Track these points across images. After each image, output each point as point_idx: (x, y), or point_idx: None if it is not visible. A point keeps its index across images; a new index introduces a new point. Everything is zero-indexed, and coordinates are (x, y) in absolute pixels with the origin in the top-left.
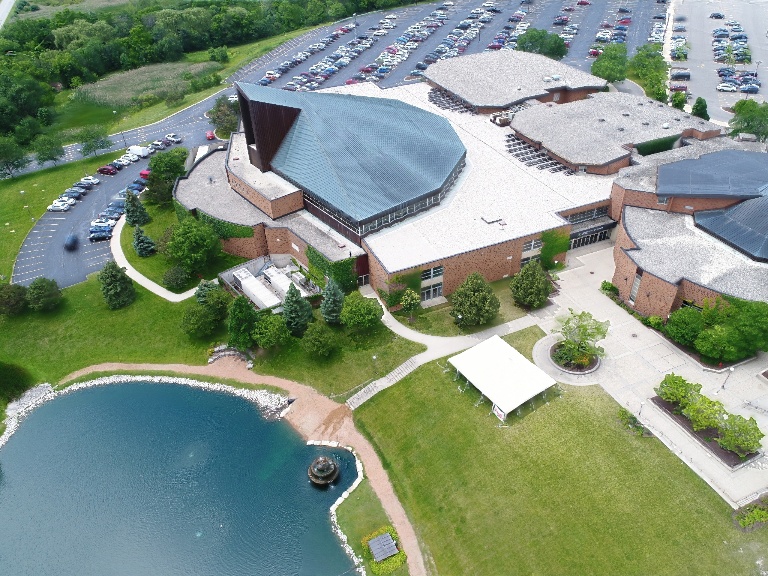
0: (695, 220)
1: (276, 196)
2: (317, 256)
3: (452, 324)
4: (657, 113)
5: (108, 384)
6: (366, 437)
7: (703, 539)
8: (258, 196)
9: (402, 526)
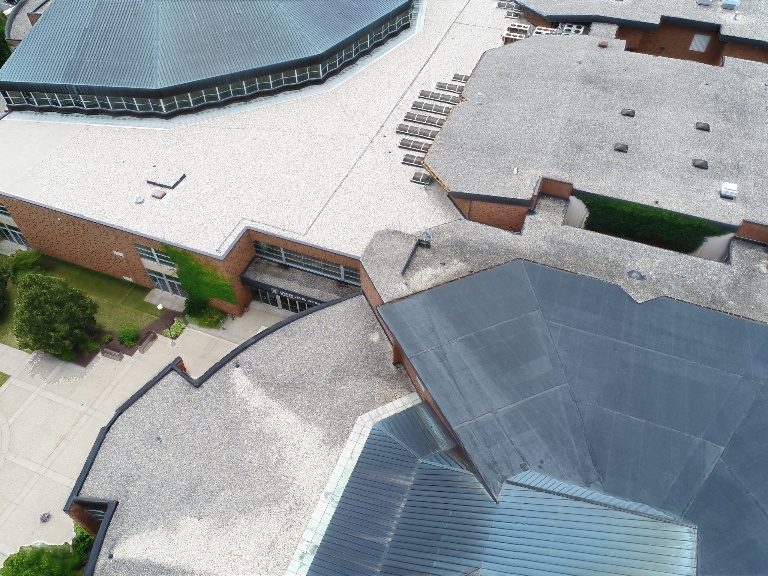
0: None
1: None
2: None
3: None
4: None
5: None
6: None
7: None
8: None
9: None
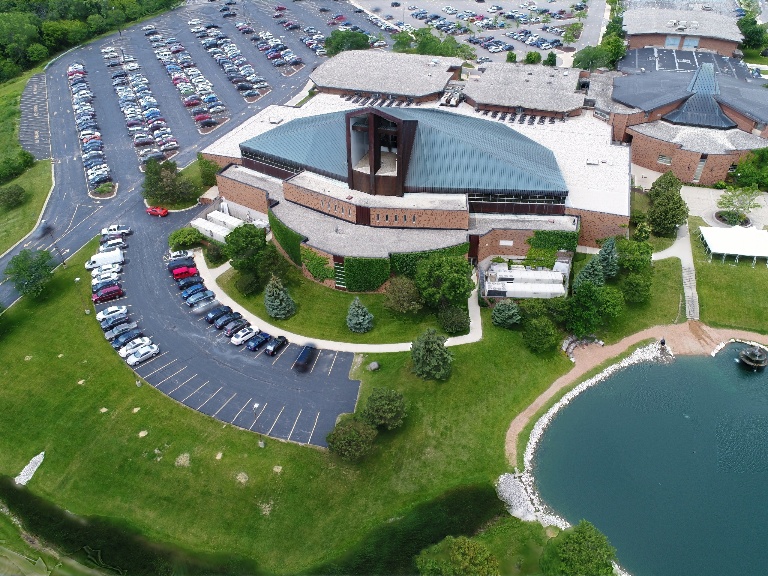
0: (672, 121)
1: (461, 206)
2: (553, 235)
3: (658, 238)
4: None
5: (544, 433)
6: (728, 328)
7: None
8: (442, 214)
9: None
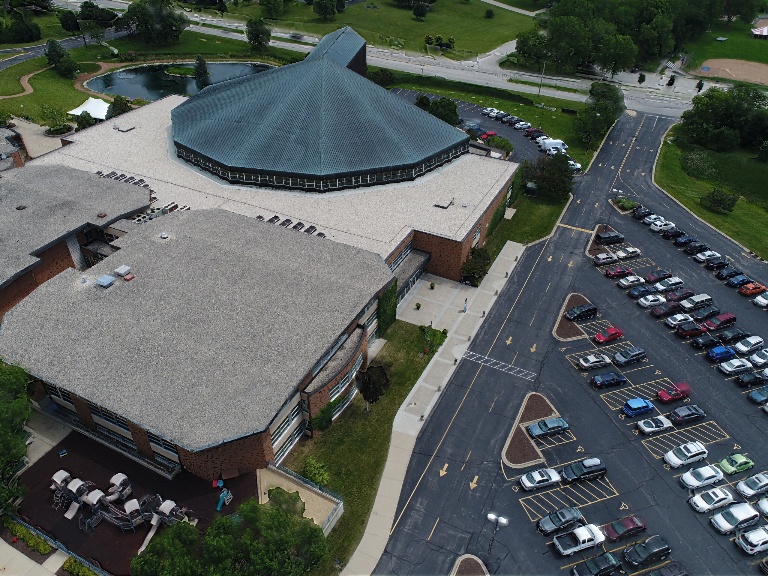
0: None
1: None
2: None
3: None
4: None
5: None
6: None
7: (5, 103)
8: None
9: None
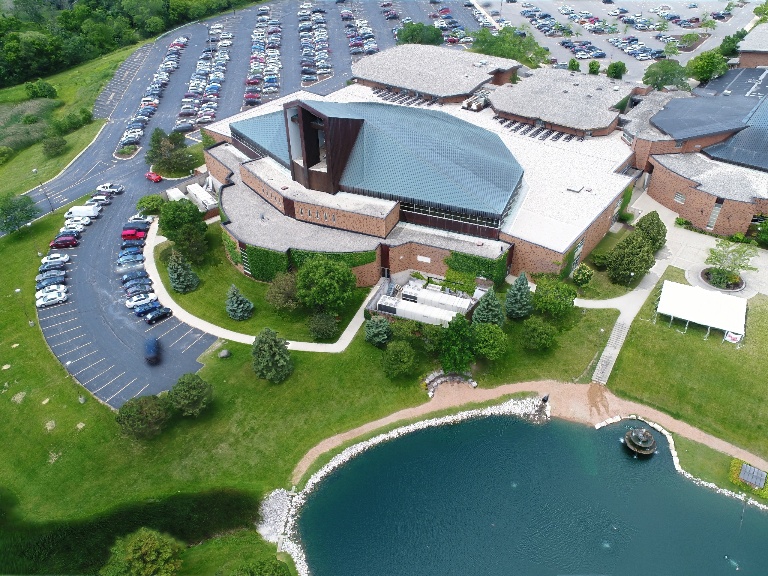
0: (710, 155)
1: (381, 213)
2: (470, 259)
3: (612, 285)
4: (593, 80)
5: (348, 460)
6: (636, 402)
7: None
8: (359, 218)
9: (741, 455)
